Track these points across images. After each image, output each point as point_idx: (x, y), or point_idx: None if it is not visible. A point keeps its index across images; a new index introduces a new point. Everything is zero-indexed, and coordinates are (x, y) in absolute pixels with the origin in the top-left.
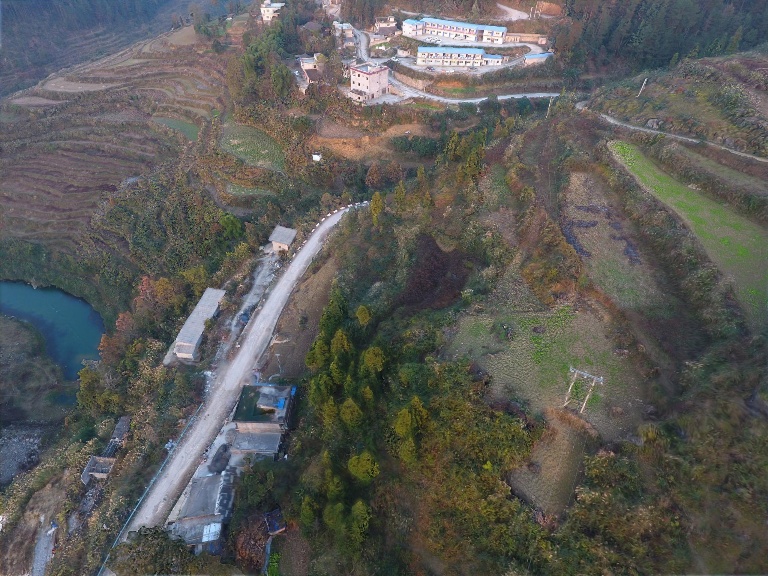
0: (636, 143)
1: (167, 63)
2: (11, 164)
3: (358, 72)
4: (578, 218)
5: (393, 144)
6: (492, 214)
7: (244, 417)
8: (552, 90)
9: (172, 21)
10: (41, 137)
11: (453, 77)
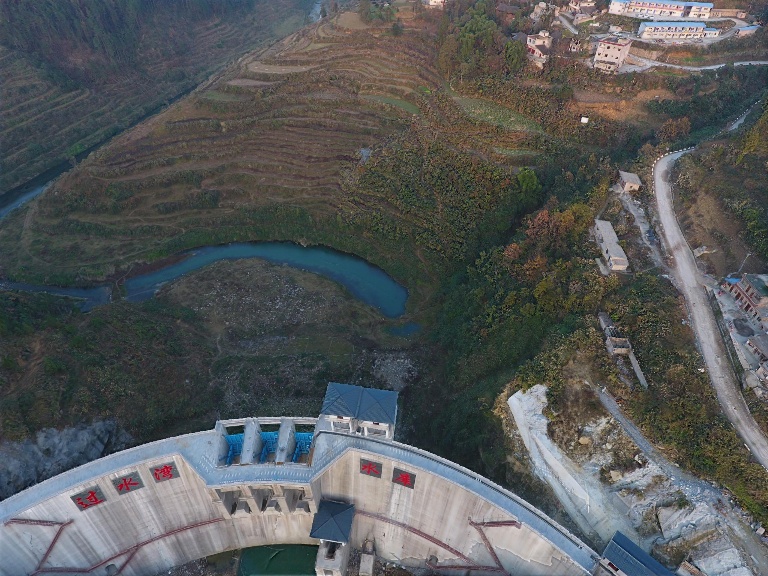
0: None
1: (350, 46)
2: (246, 139)
3: (609, 44)
4: None
5: (648, 107)
6: None
7: (767, 294)
8: (762, 58)
9: (321, 9)
10: (266, 115)
11: (683, 48)
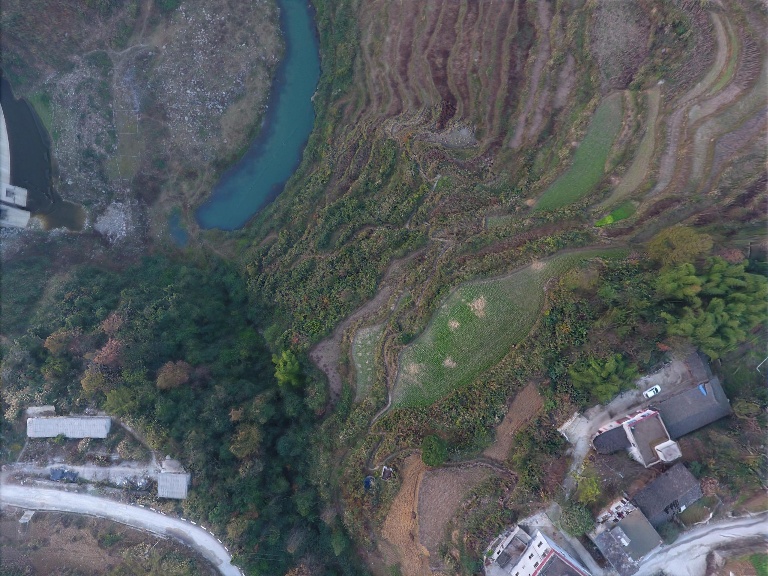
0: None
1: None
2: None
3: (537, 568)
4: None
5: None
6: None
7: None
8: None
9: None
10: None
11: None
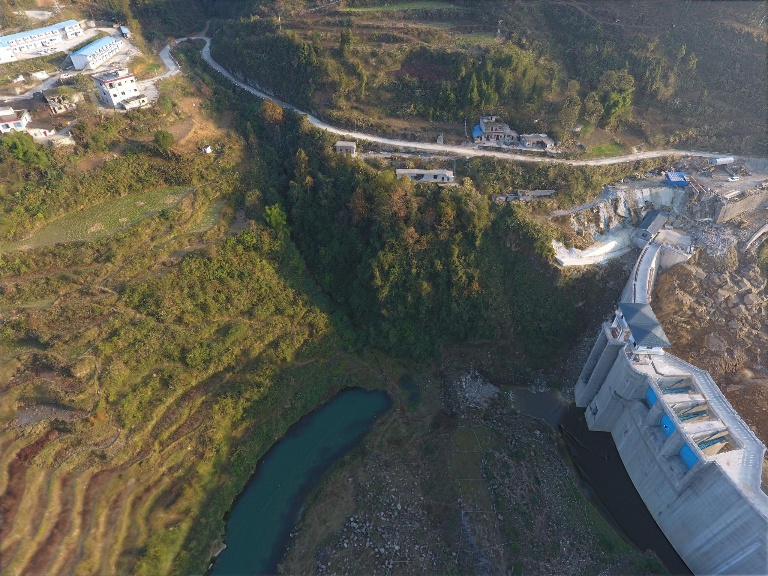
0: (344, 7)
1: None
2: None
3: (119, 80)
4: (402, 26)
5: (206, 114)
6: (384, 48)
7: (501, 123)
8: (157, 50)
9: None
10: None
11: (135, 61)
